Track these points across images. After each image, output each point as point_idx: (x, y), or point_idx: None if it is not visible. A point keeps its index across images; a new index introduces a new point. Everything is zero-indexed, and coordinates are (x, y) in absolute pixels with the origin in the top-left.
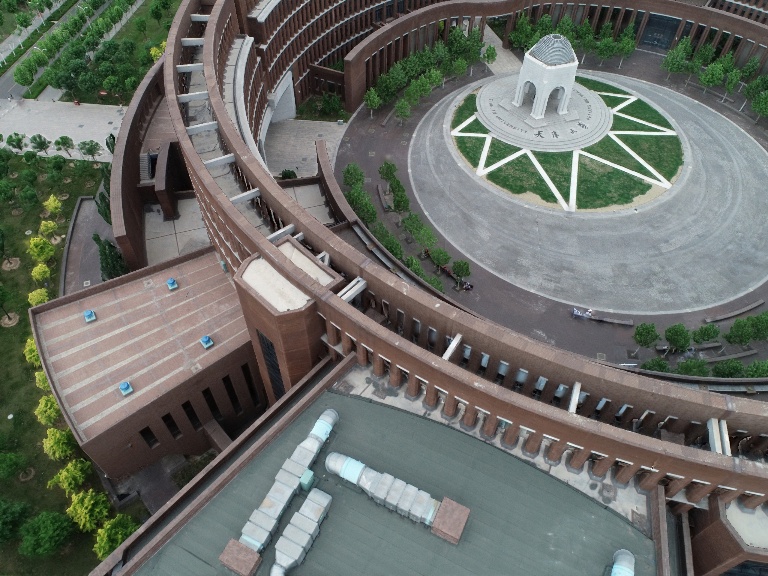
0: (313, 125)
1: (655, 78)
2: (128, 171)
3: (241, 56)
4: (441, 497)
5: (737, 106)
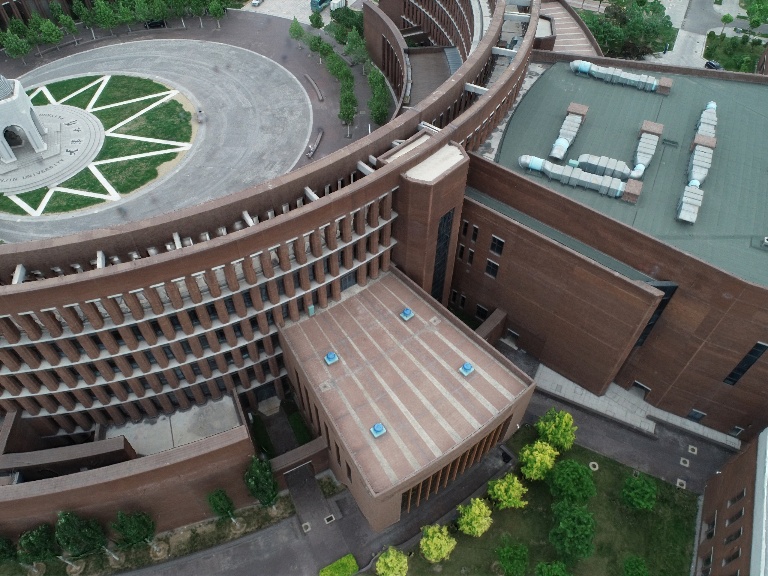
0: None
1: (19, 70)
2: None
3: None
4: (559, 123)
5: (88, 39)
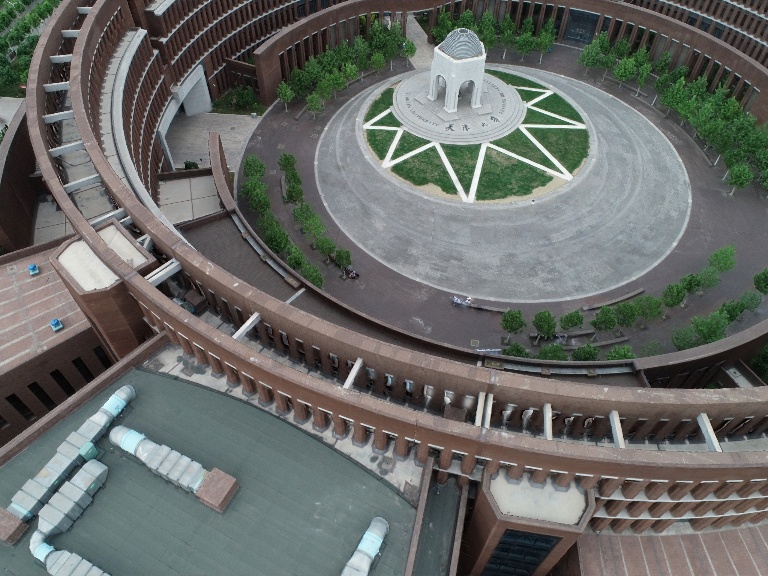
0: (227, 118)
1: (574, 73)
2: (16, 161)
3: (130, 48)
4: (220, 468)
5: (650, 100)
